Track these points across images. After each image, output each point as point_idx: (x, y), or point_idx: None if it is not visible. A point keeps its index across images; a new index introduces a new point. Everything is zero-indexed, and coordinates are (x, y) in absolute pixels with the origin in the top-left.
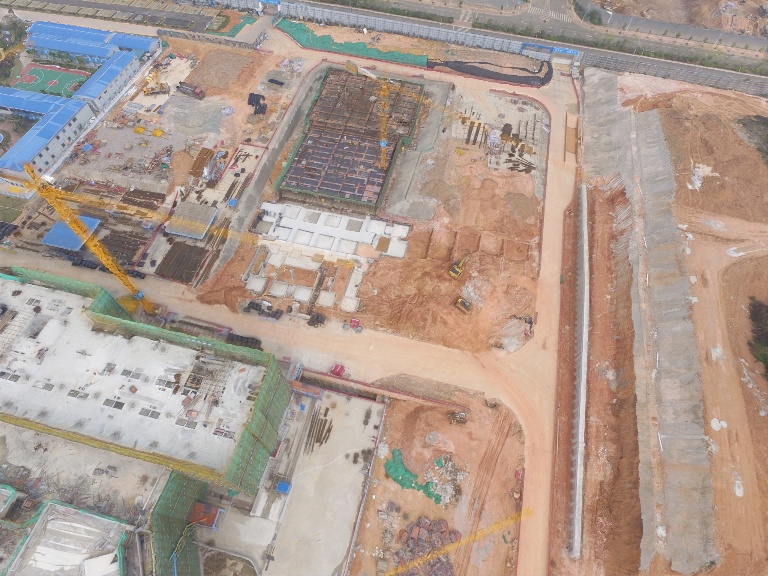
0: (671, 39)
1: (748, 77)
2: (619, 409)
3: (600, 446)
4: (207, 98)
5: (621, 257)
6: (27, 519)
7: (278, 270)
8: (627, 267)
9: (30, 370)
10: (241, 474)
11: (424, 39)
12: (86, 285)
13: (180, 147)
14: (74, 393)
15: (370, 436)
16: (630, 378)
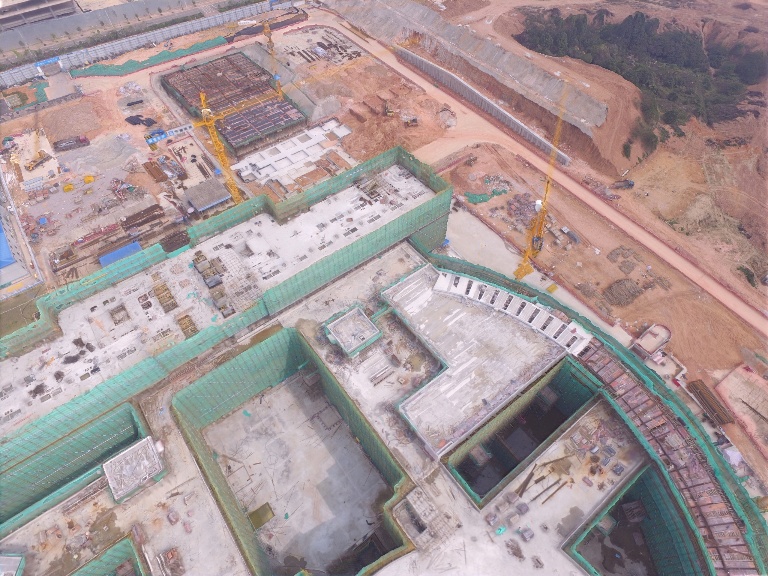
0: None
1: None
2: (519, 108)
3: (529, 126)
4: (92, 141)
5: (448, 58)
6: None
7: (296, 183)
8: (457, 58)
9: (279, 263)
10: None
11: (202, 31)
12: (252, 200)
13: (123, 174)
14: (321, 248)
15: None
16: (511, 92)
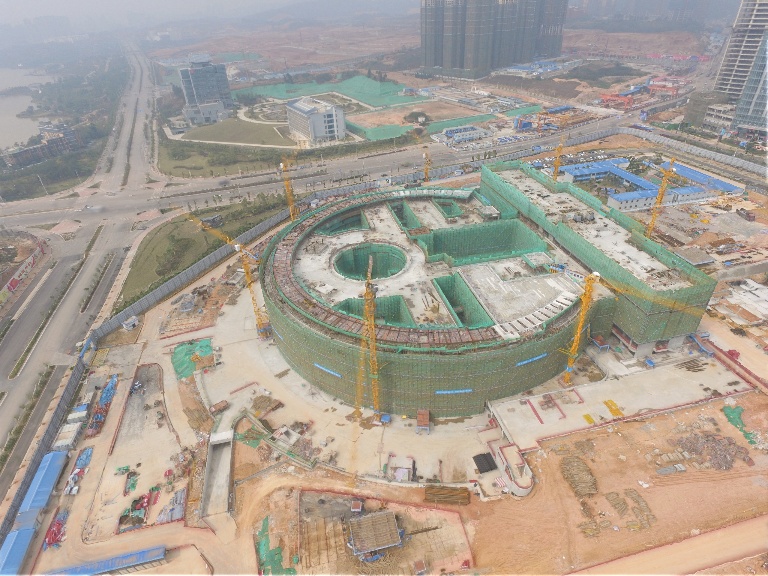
0: None
1: None
2: None
3: None
4: (754, 222)
5: None
6: None
7: (731, 304)
8: None
9: (590, 237)
10: (654, 311)
11: None
12: (639, 224)
13: (714, 231)
14: None
15: (727, 390)
16: None
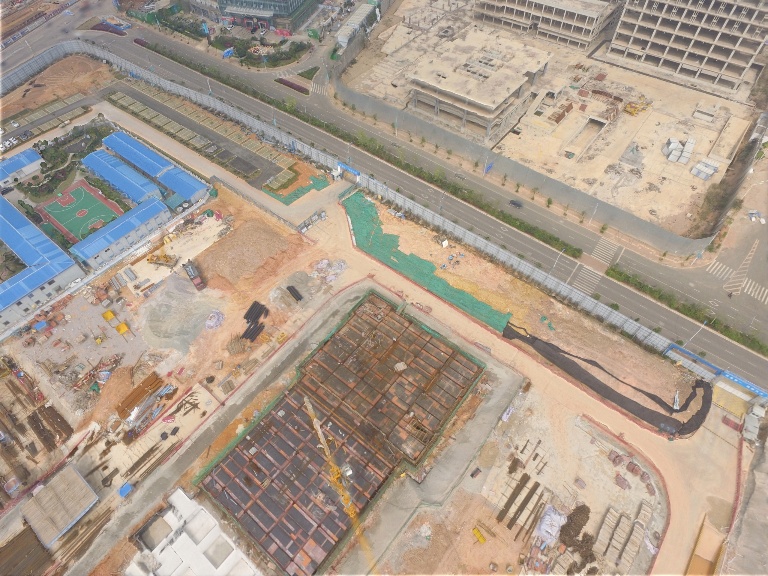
0: None
1: None
2: None
3: None
4: (207, 290)
5: None
6: None
7: None
8: None
9: None
10: None
11: (522, 279)
12: None
13: (131, 361)
14: None
15: None
16: None
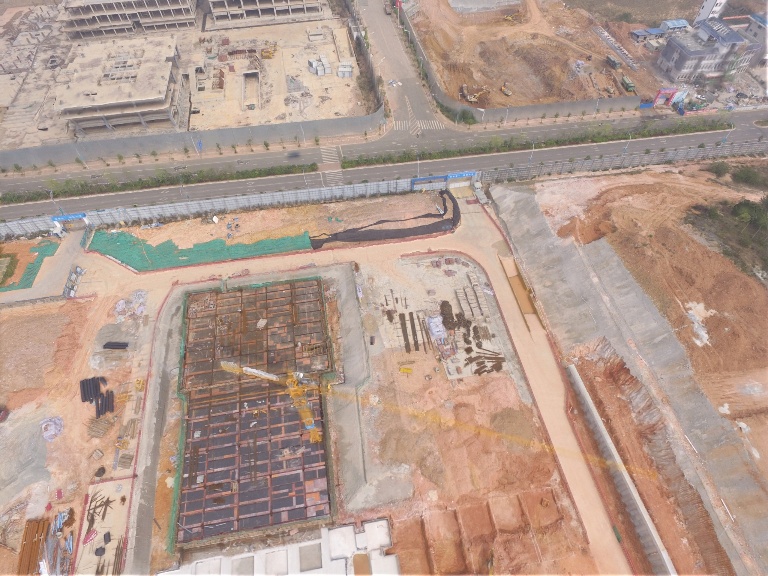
0: (550, 119)
1: (641, 142)
2: None
3: None
4: (13, 414)
5: (670, 471)
6: None
7: None
8: (689, 490)
9: None
10: None
11: (293, 206)
12: None
13: None
14: None
15: None
16: None
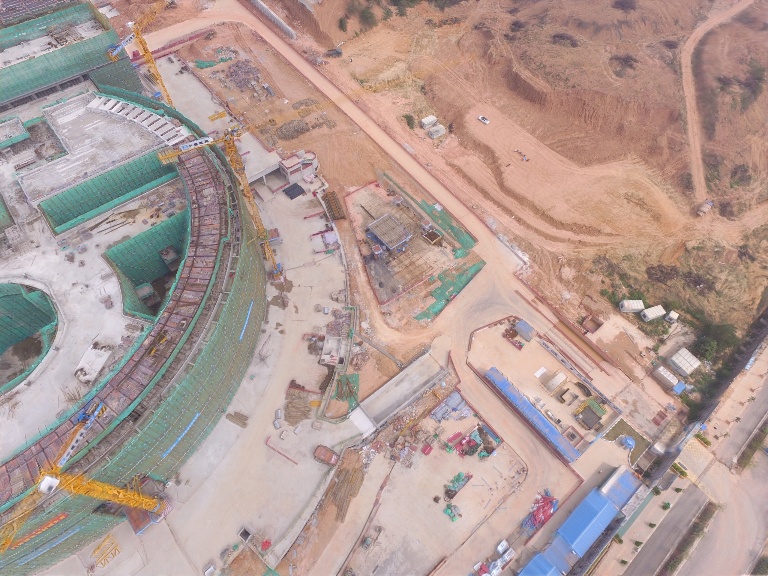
0: None
1: None
2: None
3: (276, 8)
4: None
5: None
6: (38, 133)
7: None
8: None
9: None
10: None
11: None
12: None
13: None
14: None
15: (180, 64)
16: None
